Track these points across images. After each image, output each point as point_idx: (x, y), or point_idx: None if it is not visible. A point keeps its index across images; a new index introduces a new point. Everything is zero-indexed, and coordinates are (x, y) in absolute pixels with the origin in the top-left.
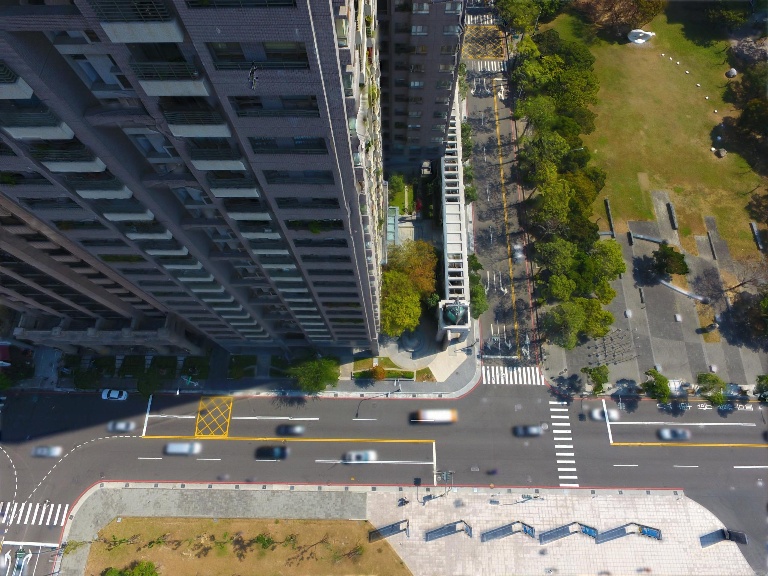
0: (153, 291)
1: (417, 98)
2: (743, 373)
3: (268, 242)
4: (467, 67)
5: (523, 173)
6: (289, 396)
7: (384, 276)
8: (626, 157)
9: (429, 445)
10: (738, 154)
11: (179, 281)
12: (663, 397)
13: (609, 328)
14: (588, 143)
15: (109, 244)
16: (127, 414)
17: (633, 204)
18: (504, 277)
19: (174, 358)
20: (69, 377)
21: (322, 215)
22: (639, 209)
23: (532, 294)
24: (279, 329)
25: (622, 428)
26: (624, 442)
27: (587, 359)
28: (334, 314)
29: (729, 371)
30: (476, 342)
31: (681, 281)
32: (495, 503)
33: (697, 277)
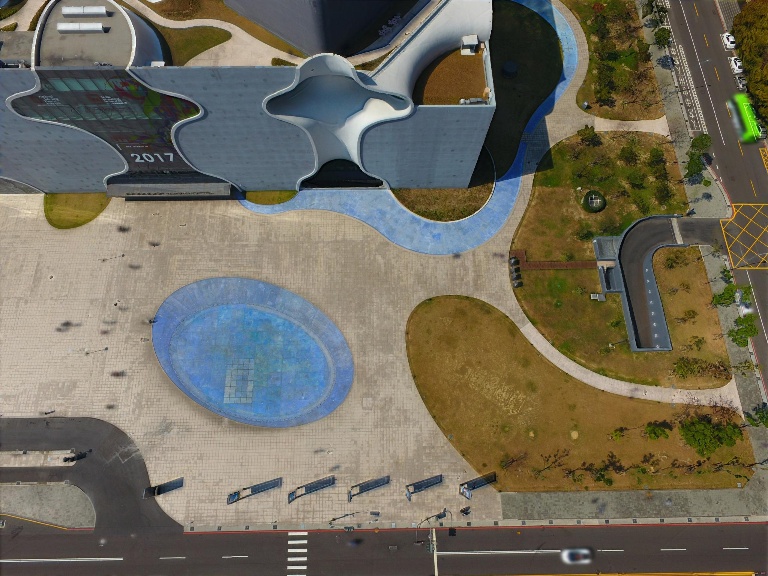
0: None
1: None
2: None
3: None
4: None
5: None
6: None
7: None
8: None
9: (442, 574)
10: None
11: None
12: None
13: None
14: None
15: None
16: None
17: None
18: None
19: None
20: None
21: None
22: None
23: None
24: None
25: None
26: None
27: None
28: None
29: None
30: None
31: None
32: (375, 513)
33: None
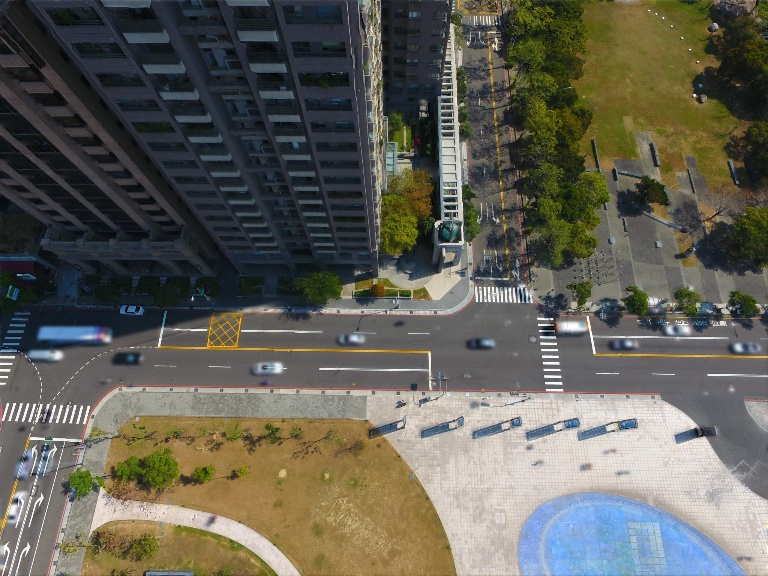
0: (176, 176)
1: (415, 30)
2: (718, 293)
3: (282, 106)
4: (463, 21)
5: (515, 116)
6: (295, 312)
7: (384, 199)
8: (612, 102)
9: (425, 355)
10: (718, 100)
11: (200, 160)
12: (642, 309)
13: (593, 250)
14: (577, 90)
15: (143, 108)
16: (143, 328)
17: (618, 144)
18: (496, 208)
19: (187, 278)
20: (89, 295)
21: (331, 65)
22: (624, 148)
23: (522, 223)
24: (287, 238)
25: (604, 341)
26: (606, 353)
27: (573, 281)
28: (338, 210)
29: (705, 291)
30: (469, 266)
31: (662, 212)
32: (486, 405)
33: (677, 209)
